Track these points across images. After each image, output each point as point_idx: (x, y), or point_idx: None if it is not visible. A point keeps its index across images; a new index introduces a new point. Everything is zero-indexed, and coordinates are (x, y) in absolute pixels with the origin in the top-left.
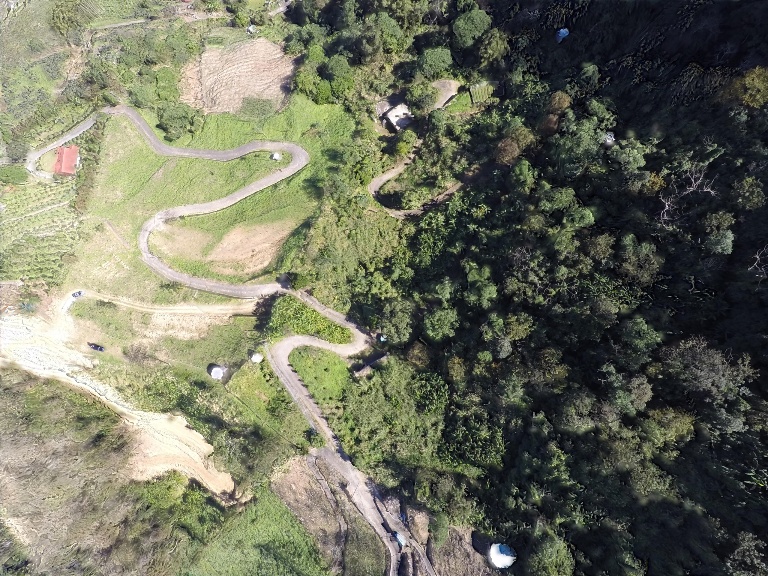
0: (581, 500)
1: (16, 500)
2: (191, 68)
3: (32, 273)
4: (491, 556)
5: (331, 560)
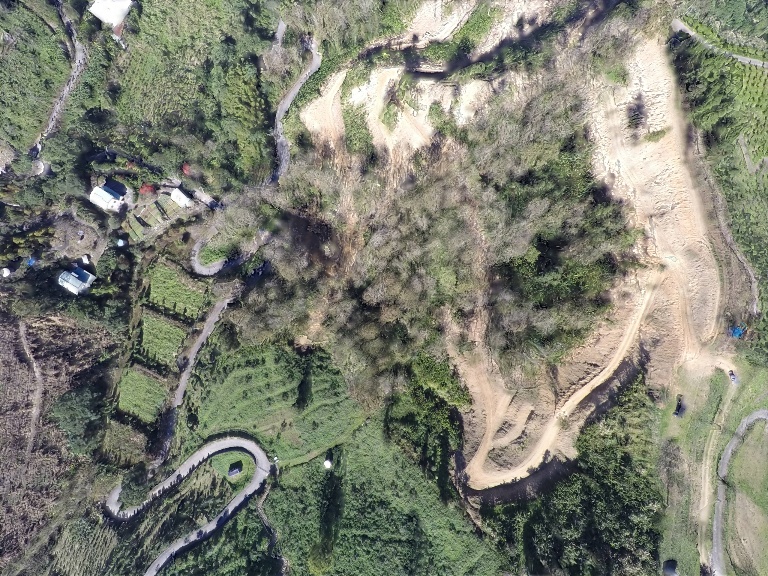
0: None
1: (458, 248)
2: None
3: (763, 325)
4: None
5: None
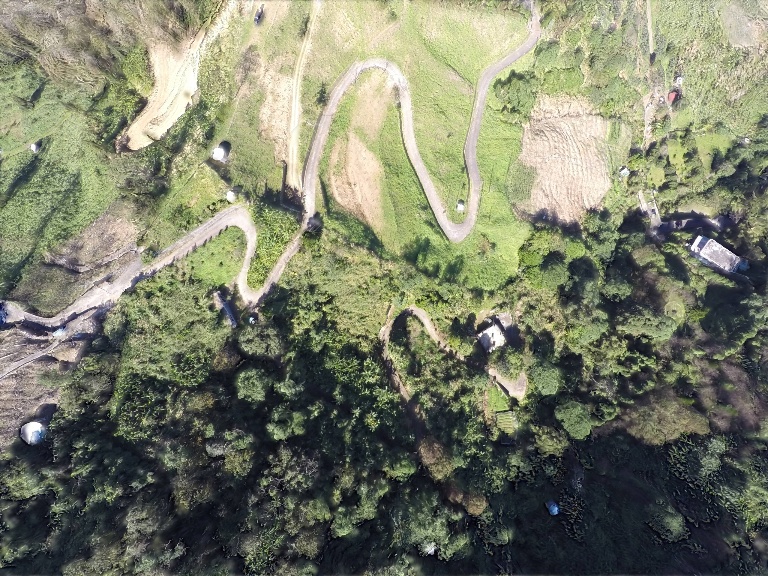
0: (70, 512)
1: None
2: (583, 105)
3: None
4: (31, 423)
5: (56, 252)
